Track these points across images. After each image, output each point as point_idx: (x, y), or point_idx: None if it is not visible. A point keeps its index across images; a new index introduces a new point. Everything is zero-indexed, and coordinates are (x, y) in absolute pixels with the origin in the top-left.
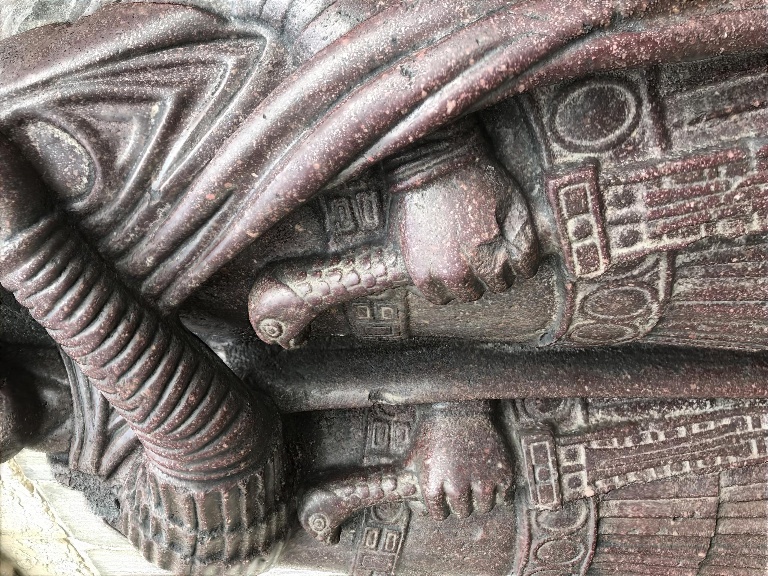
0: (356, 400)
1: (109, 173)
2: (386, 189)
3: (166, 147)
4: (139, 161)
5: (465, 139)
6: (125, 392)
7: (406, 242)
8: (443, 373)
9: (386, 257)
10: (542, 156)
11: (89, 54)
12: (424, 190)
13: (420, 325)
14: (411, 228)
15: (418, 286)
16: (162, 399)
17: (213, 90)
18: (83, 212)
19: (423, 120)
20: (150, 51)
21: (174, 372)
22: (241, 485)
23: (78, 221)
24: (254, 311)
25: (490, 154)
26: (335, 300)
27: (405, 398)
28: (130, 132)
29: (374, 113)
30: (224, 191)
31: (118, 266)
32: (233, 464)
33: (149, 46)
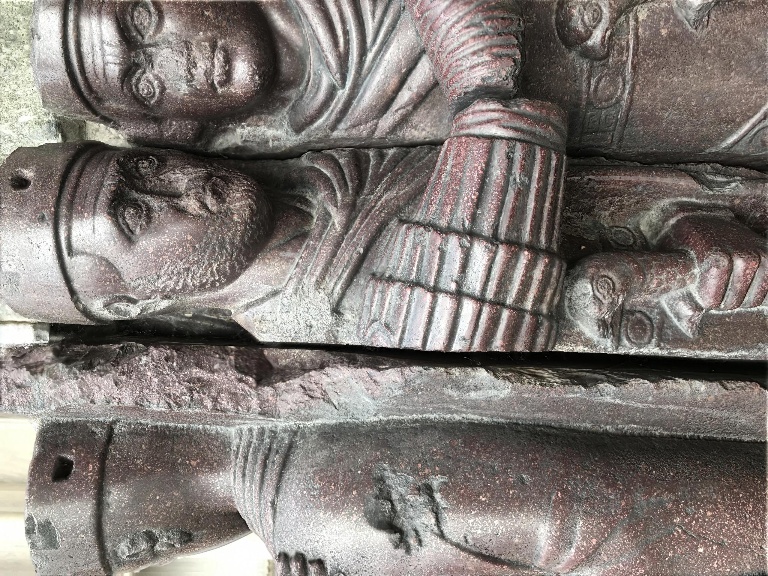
0: None
1: None
2: None
3: None
4: None
5: None
6: None
7: None
8: None
9: None
10: None
11: None
12: None
13: None
14: None
15: None
16: None
17: None
18: None
19: None
20: None
21: None
22: None
23: None
24: None
25: None
26: None
27: None
28: None
29: None
30: None
31: None
32: None
33: None
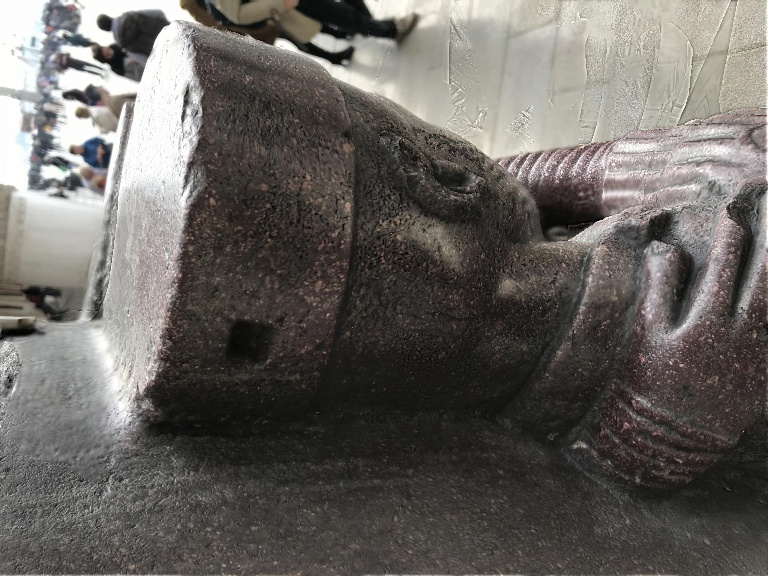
0: None
1: None
2: None
3: None
4: None
5: None
6: None
7: None
8: None
9: None
10: None
11: None
12: None
13: None
14: None
15: None
16: None
17: None
18: None
19: None
20: None
21: None
22: None
23: None
24: None
25: None
26: None
27: None
28: None
29: None
30: None
31: None
32: None
33: None
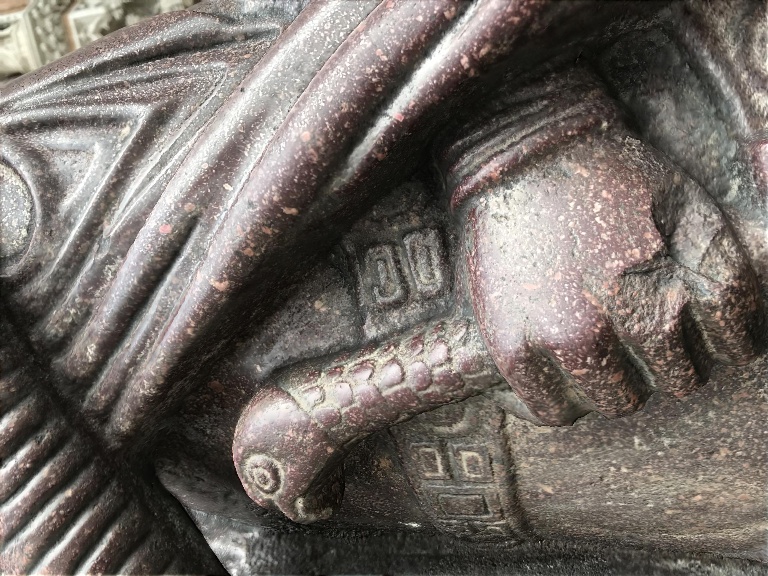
0: None
1: (51, 217)
2: (453, 225)
3: (128, 176)
4: (91, 198)
5: (578, 93)
6: (11, 572)
7: (479, 287)
8: None
9: (450, 330)
10: (737, 117)
11: (58, 72)
12: (508, 189)
13: (538, 497)
14: (486, 259)
15: (505, 372)
16: None
17: (203, 101)
18: (16, 278)
19: (483, 18)
20: (132, 64)
21: (97, 543)
22: None
23: (9, 293)
24: (236, 440)
25: (630, 123)
26: (363, 417)
27: None
28: (89, 163)
29: (397, 25)
30: (184, 218)
31: (55, 365)
32: None
33: (131, 56)
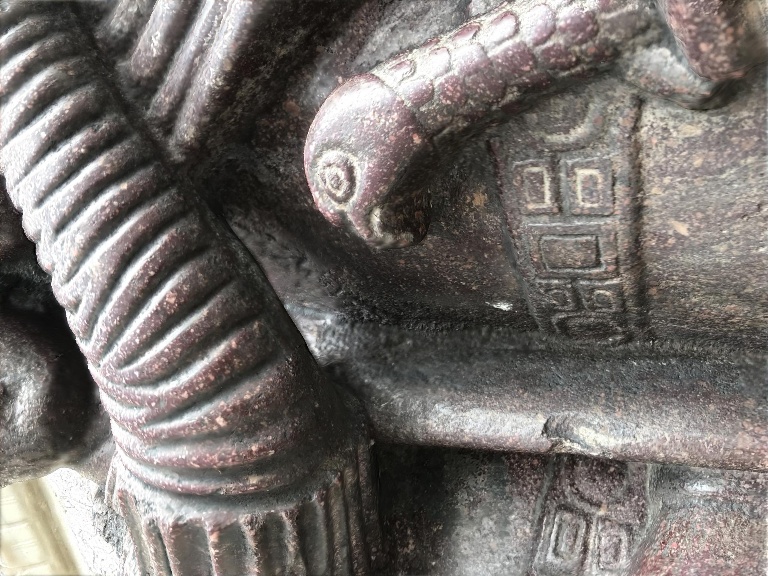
0: (517, 431)
1: None
2: None
3: None
4: None
5: None
6: (63, 264)
7: None
8: (715, 402)
9: None
10: None
11: None
12: None
13: (666, 244)
14: None
15: None
16: (119, 289)
17: None
18: None
19: None
20: None
21: (151, 242)
22: (246, 525)
23: None
24: (308, 137)
25: None
26: (461, 89)
27: (622, 441)
28: None
29: None
30: None
31: (120, 67)
32: (235, 471)
33: None
